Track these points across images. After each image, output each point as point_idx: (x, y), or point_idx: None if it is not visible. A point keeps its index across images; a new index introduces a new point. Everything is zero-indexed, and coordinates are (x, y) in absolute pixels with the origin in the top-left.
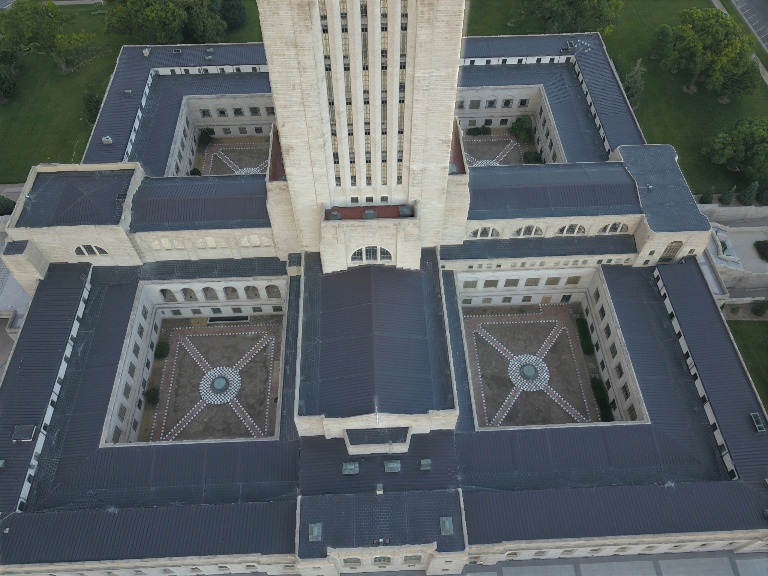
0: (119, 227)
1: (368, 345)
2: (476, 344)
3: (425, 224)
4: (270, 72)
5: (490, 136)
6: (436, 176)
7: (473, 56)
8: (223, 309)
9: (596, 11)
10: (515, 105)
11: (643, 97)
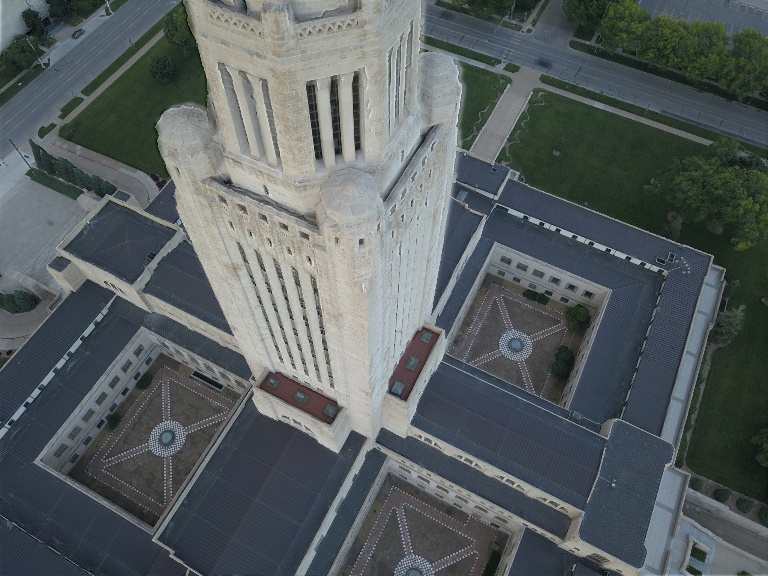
0: (131, 287)
1: (245, 508)
2: (387, 521)
3: (356, 421)
4: (212, 285)
5: (544, 307)
6: (360, 404)
7: (560, 226)
8: (204, 372)
9: (738, 221)
10: (579, 293)
11: (740, 336)
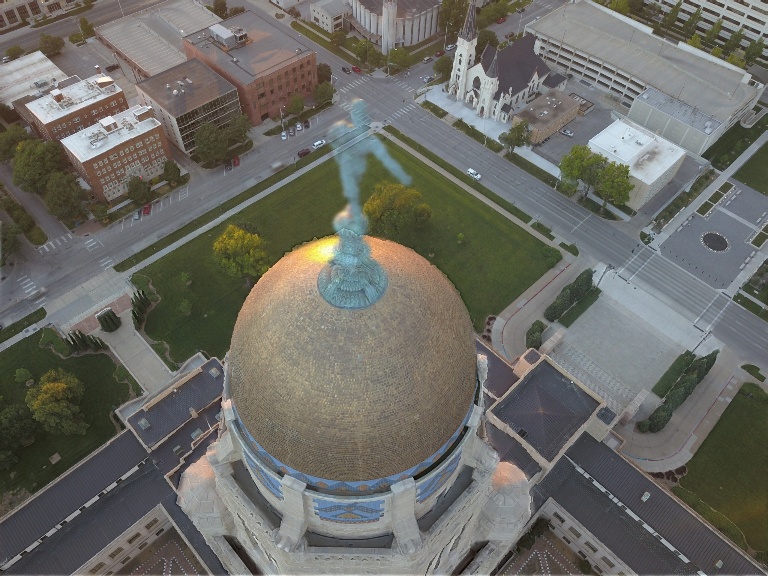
0: (488, 410)
1: None
2: None
3: None
4: None
5: None
6: None
7: None
8: None
9: None
10: None
11: None
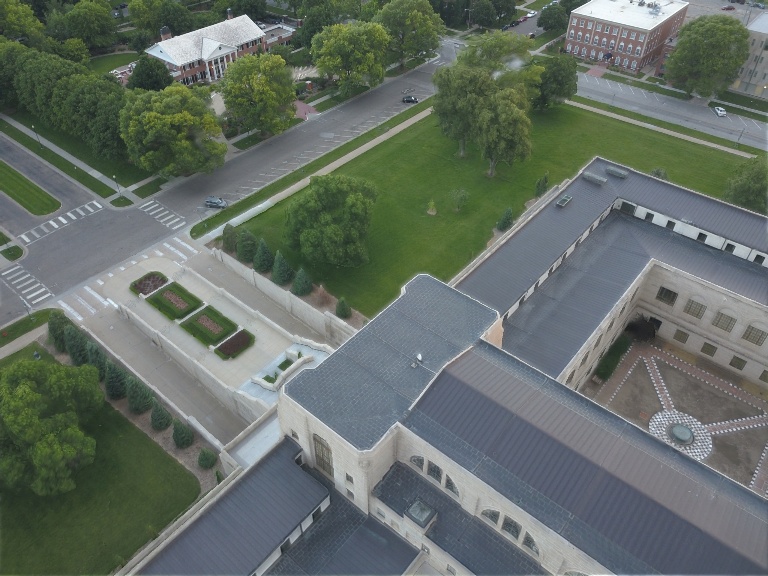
0: None
1: None
2: None
3: None
4: None
5: None
6: None
7: None
8: None
9: None
10: None
11: None
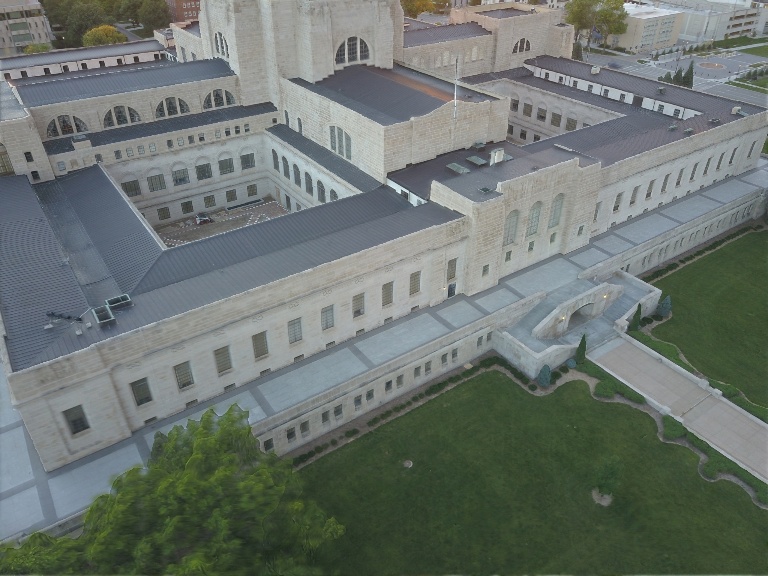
0: None
1: None
2: None
3: None
4: None
5: None
6: None
7: (324, 236)
8: None
9: None
10: None
11: None
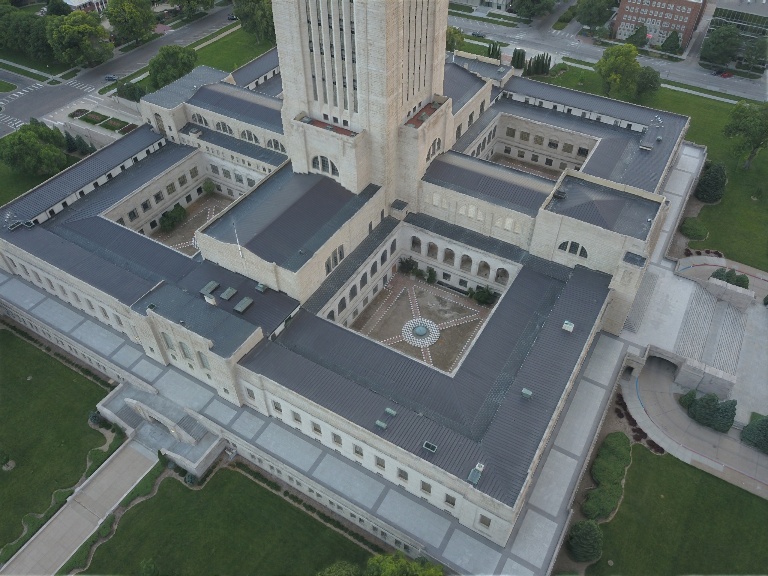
0: None
1: None
2: None
3: None
4: None
5: None
6: None
7: (108, 262)
8: None
9: None
10: None
11: None
